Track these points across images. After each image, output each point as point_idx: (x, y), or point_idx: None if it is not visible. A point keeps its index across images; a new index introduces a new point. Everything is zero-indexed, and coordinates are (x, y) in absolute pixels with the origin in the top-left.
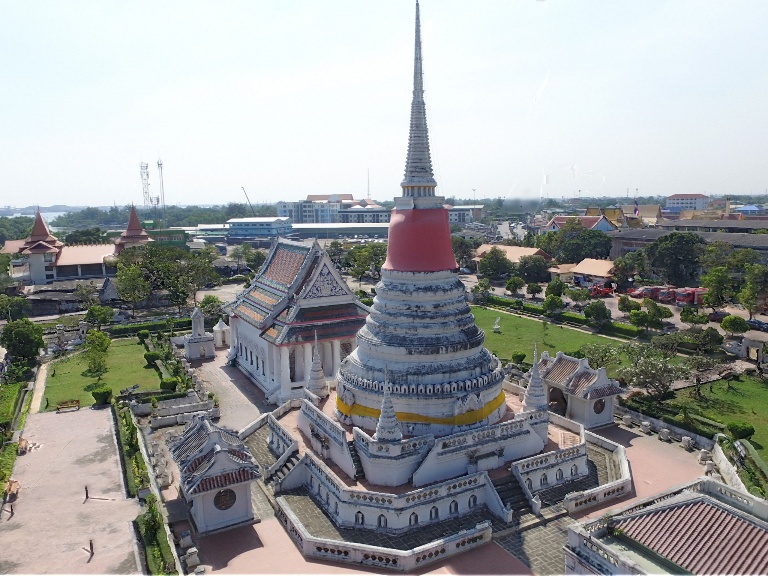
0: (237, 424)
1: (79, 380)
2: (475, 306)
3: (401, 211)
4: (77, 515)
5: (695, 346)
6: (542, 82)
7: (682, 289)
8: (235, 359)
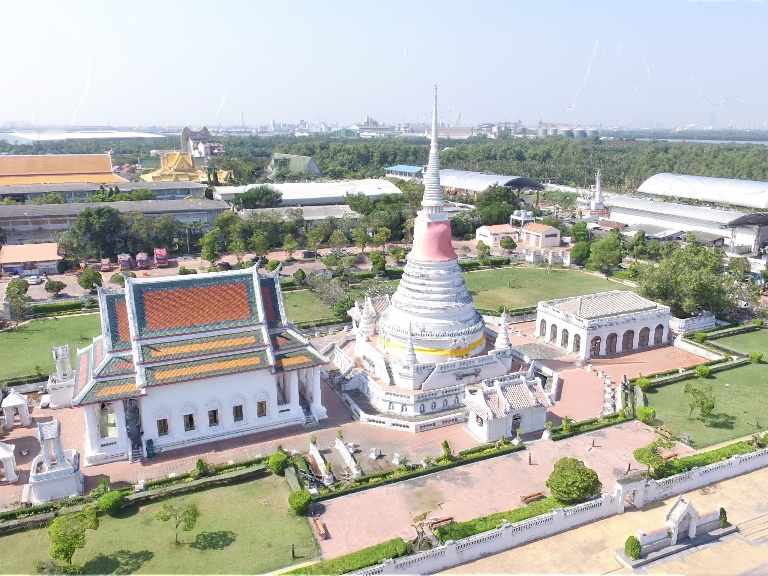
0: (365, 435)
1: (162, 568)
2: (34, 321)
3: (442, 222)
4: (554, 463)
5: (292, 284)
6: (223, 96)
7: (144, 255)
8: (152, 446)
